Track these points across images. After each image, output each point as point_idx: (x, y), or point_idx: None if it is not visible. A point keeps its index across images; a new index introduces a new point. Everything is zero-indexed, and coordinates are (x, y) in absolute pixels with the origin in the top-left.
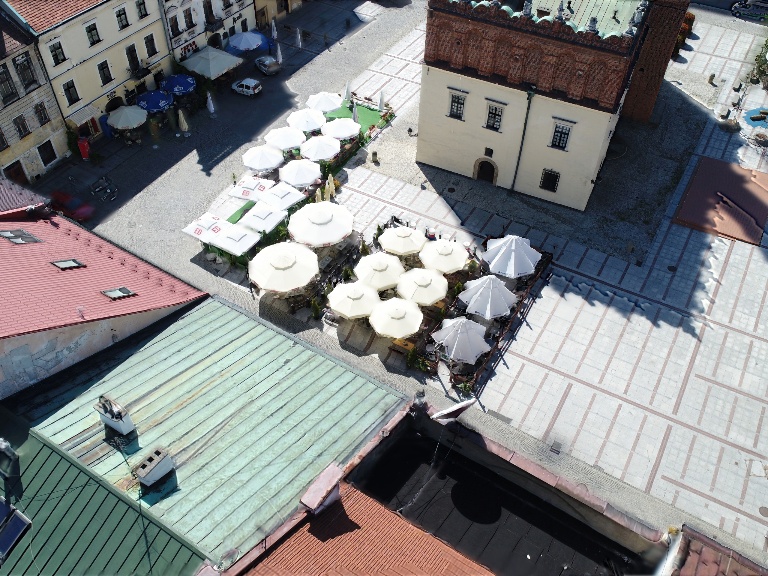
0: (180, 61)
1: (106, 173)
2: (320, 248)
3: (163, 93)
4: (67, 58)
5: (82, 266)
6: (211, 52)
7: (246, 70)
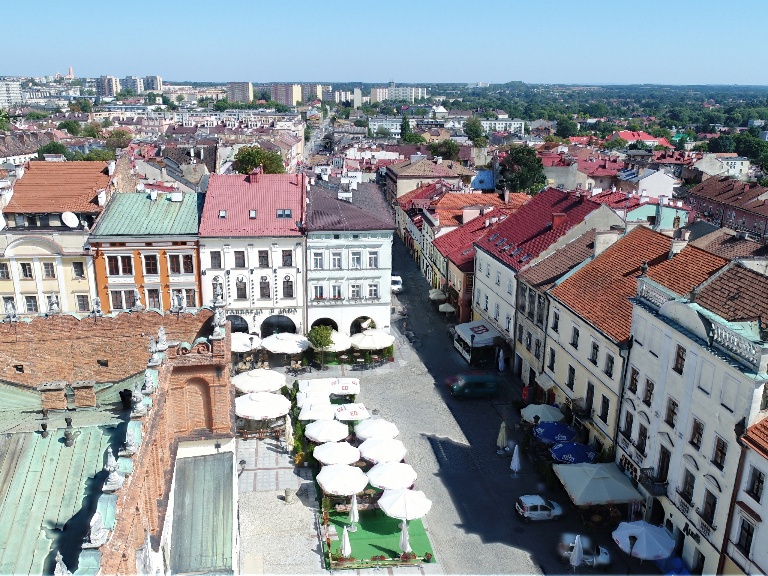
0: (620, 465)
1: (497, 408)
2: None
3: (559, 435)
4: None
5: (250, 217)
6: (597, 470)
7: (600, 543)
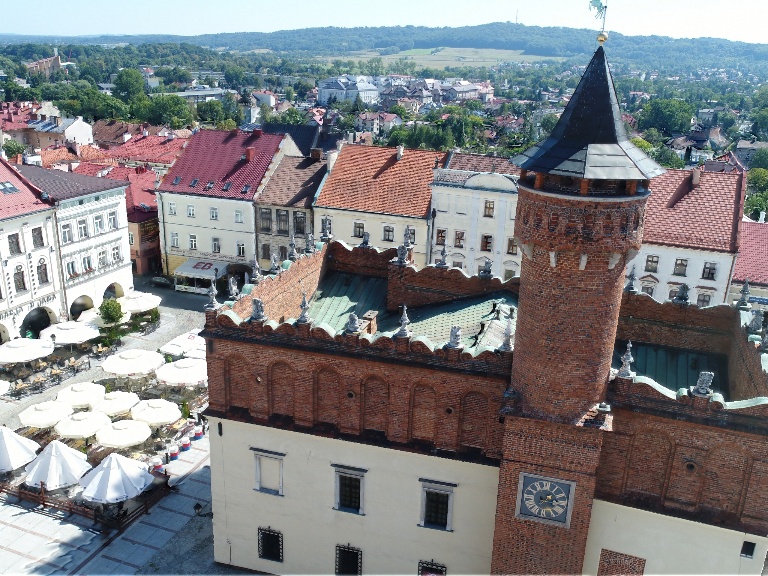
0: None
1: None
2: (183, 393)
3: None
4: (333, 233)
5: None
6: None
7: None
